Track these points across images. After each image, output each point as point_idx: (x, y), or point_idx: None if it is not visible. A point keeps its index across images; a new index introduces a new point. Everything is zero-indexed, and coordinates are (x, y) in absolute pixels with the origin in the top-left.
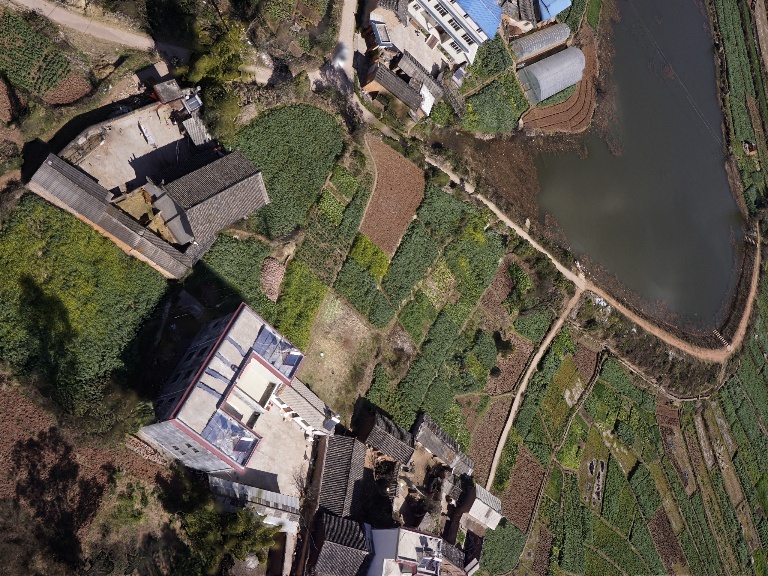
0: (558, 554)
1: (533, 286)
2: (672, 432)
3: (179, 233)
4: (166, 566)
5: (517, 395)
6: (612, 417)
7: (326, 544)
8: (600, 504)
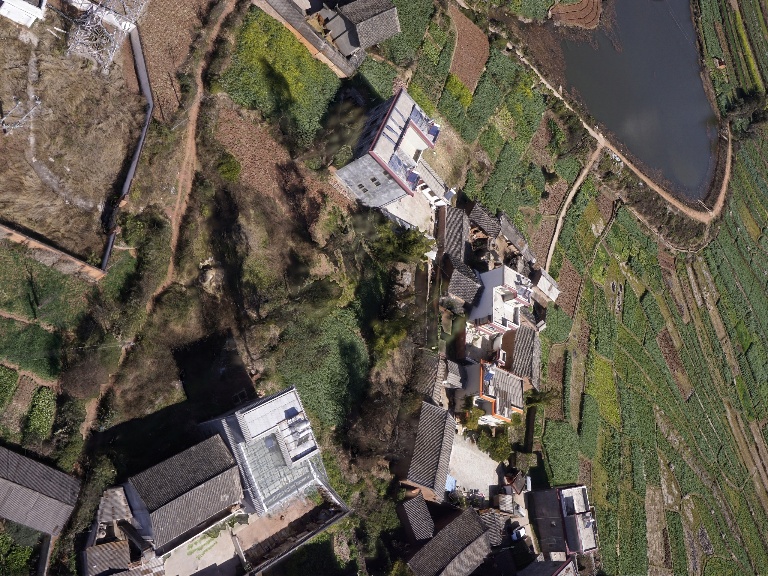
0: (594, 341)
1: (566, 139)
2: (670, 274)
3: (345, 47)
4: (359, 266)
5: (560, 218)
6: (626, 252)
7: (454, 273)
8: (621, 315)
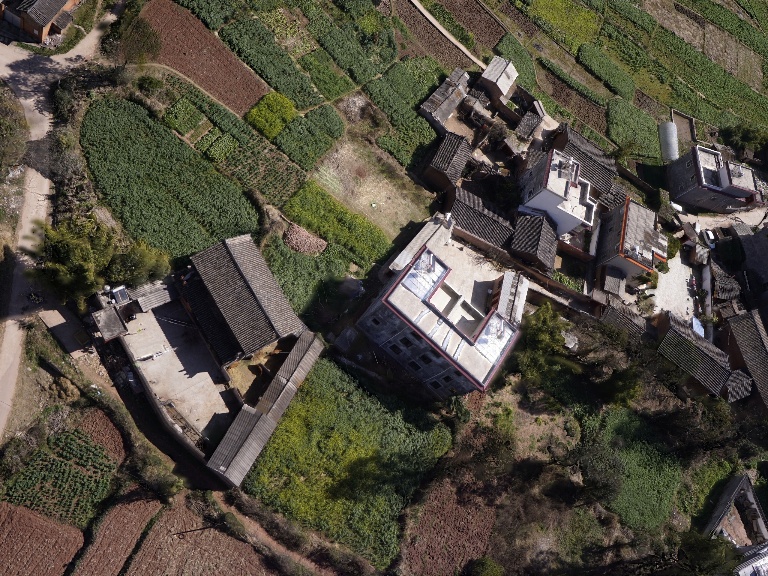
0: (520, 2)
1: None
2: None
3: None
4: (538, 392)
5: None
6: None
7: (538, 255)
8: None
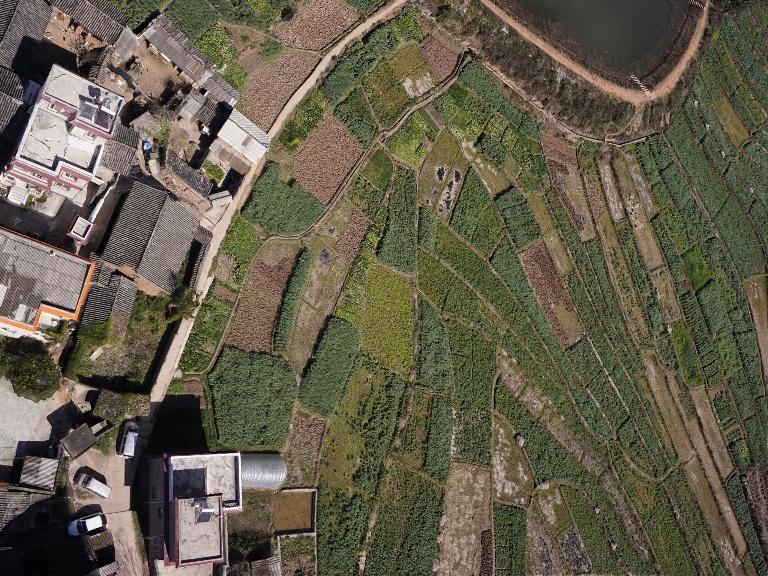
0: (377, 244)
1: None
2: (565, 170)
3: None
4: None
5: (326, 56)
6: (475, 127)
7: None
8: (449, 213)
